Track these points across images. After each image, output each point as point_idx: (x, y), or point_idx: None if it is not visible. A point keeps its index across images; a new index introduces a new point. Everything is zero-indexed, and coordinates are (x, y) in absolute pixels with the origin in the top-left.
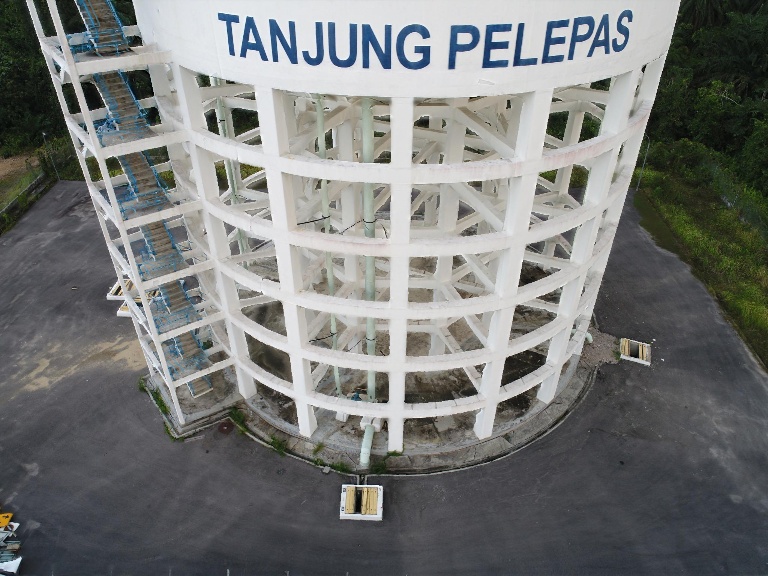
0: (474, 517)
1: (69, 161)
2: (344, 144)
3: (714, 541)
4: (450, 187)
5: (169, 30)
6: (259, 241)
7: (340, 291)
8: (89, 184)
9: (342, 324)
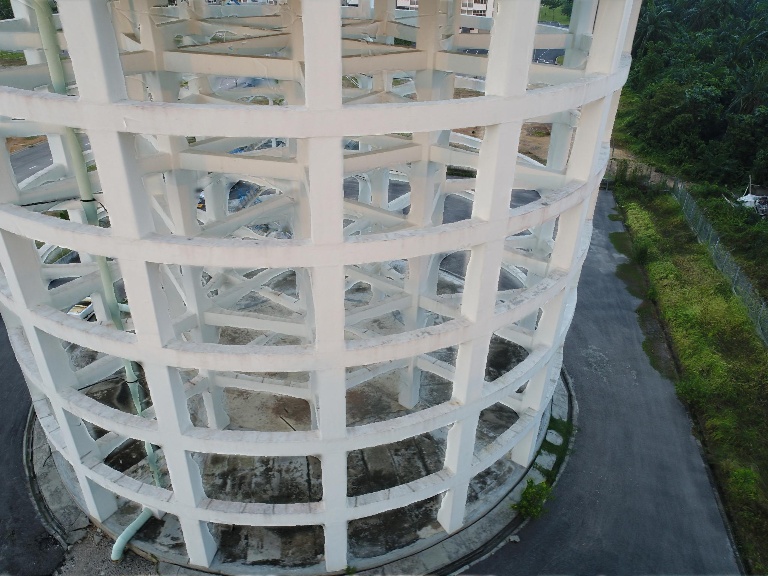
0: (4, 363)
1: (662, 193)
2: None
3: None
4: None
5: None
6: None
7: (199, 210)
8: None
9: (290, 313)
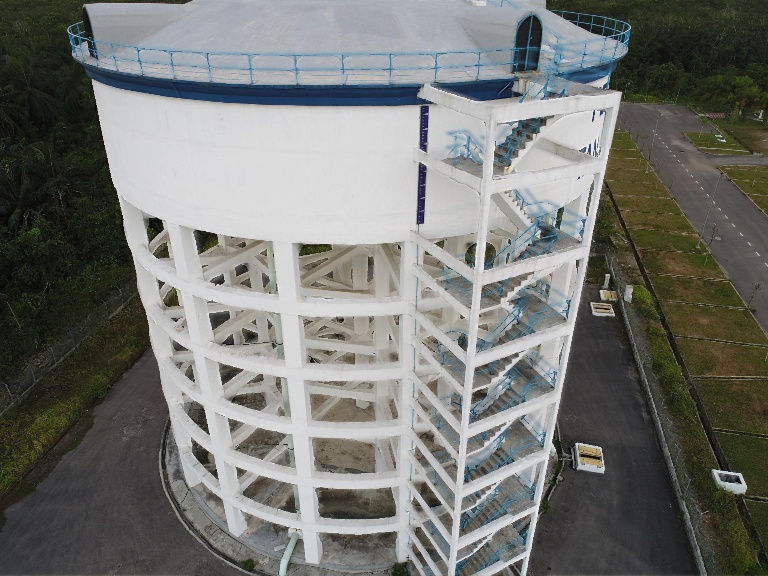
0: (588, 406)
1: None
2: (460, 249)
3: (584, 326)
4: (467, 244)
5: (532, 191)
6: (174, 525)
7: None
8: (468, 427)
9: (389, 446)
